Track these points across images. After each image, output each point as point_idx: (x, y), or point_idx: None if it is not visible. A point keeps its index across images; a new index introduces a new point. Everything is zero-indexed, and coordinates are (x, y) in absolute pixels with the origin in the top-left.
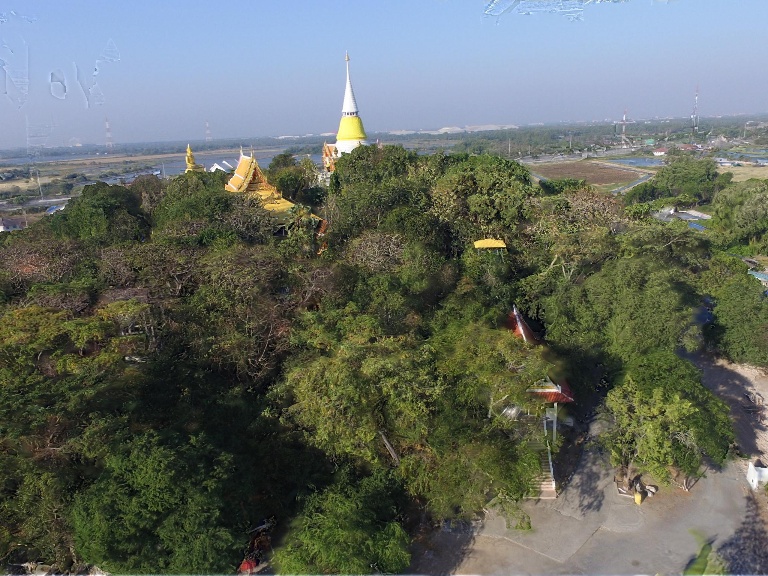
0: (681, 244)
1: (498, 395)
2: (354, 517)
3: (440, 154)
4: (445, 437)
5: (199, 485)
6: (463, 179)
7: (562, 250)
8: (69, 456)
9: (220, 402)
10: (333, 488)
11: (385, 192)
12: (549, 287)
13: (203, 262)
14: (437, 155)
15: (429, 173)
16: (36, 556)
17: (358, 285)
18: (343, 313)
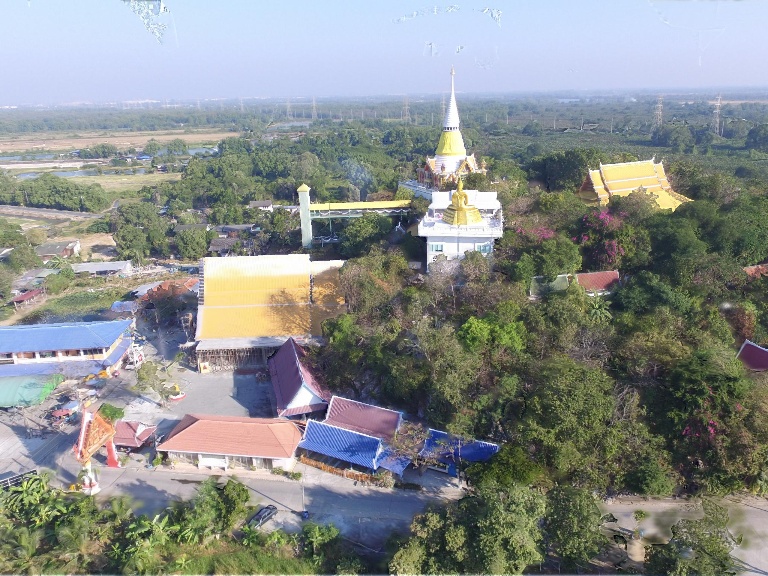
0: None
1: None
2: None
3: None
4: None
5: None
6: None
7: None
8: None
9: None
10: None
11: None
12: None
13: None
14: None
15: None
16: None
17: None
18: None
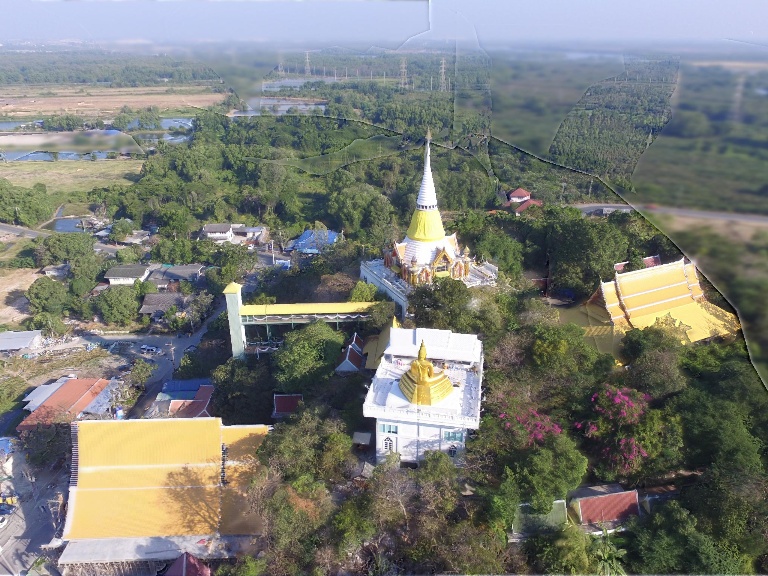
0: None
1: None
2: None
3: (567, 216)
4: None
5: None
6: None
7: None
8: None
9: None
10: None
11: None
12: None
13: None
14: None
15: None
16: None
17: None
18: None
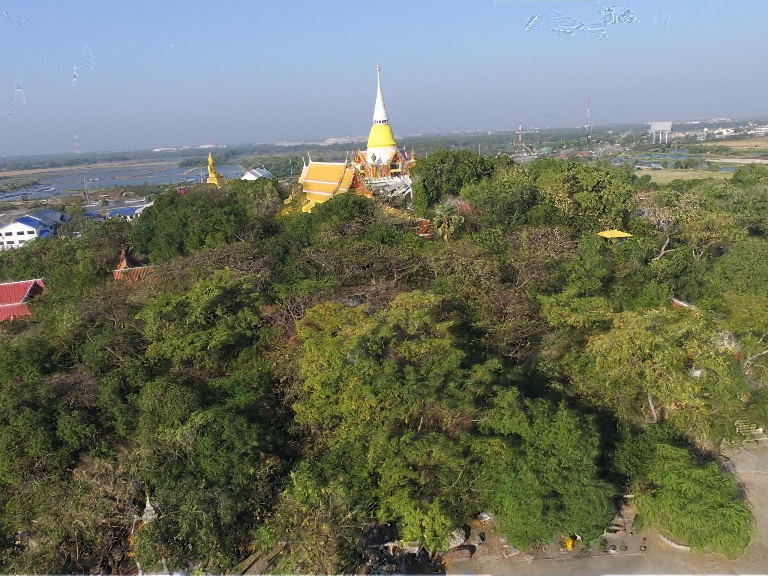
0: (754, 229)
1: (756, 351)
2: (686, 460)
3: (506, 158)
4: (734, 387)
5: (587, 442)
6: (567, 178)
7: (698, 235)
8: (472, 429)
9: (515, 379)
10: (628, 444)
11: (526, 190)
12: (679, 269)
13: (434, 256)
14: (504, 159)
15: (524, 174)
16: (382, 538)
17: (555, 272)
18: (568, 296)
